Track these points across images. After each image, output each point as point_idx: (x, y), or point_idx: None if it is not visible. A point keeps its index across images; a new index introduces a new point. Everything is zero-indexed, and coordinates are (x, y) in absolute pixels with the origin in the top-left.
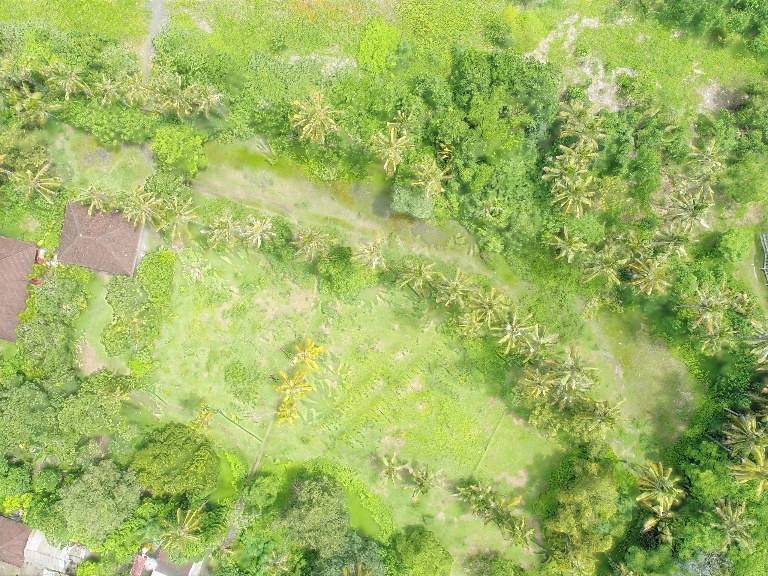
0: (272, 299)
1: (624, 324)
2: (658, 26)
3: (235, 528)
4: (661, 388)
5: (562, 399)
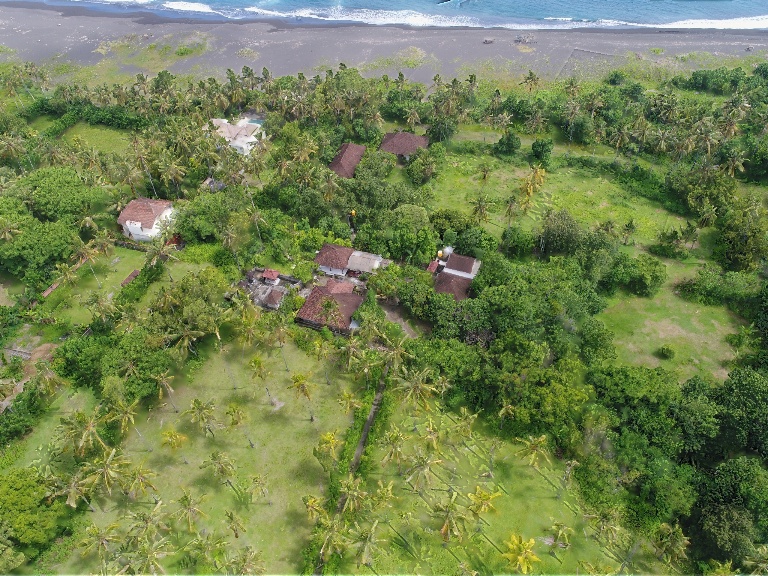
0: (503, 173)
1: None
2: (686, 90)
3: None
4: (767, 204)
5: None
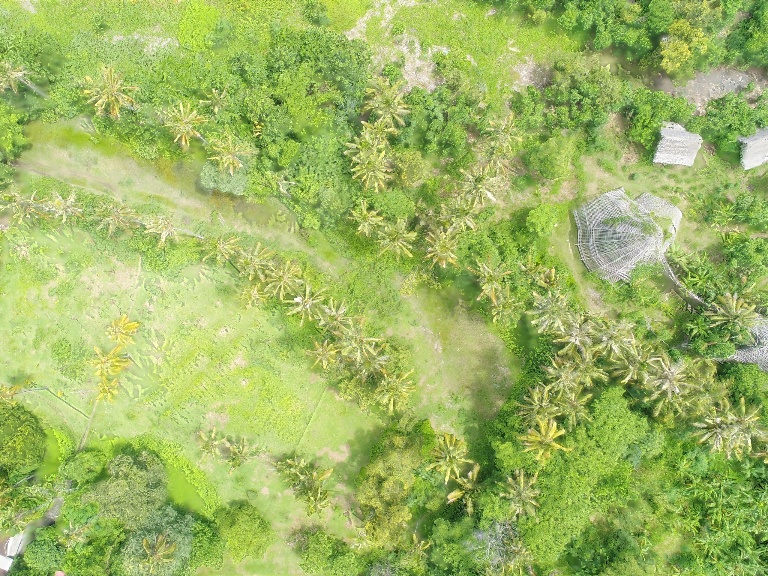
0: (97, 277)
1: (442, 300)
2: (472, 4)
3: (61, 503)
4: (479, 363)
5: (361, 372)
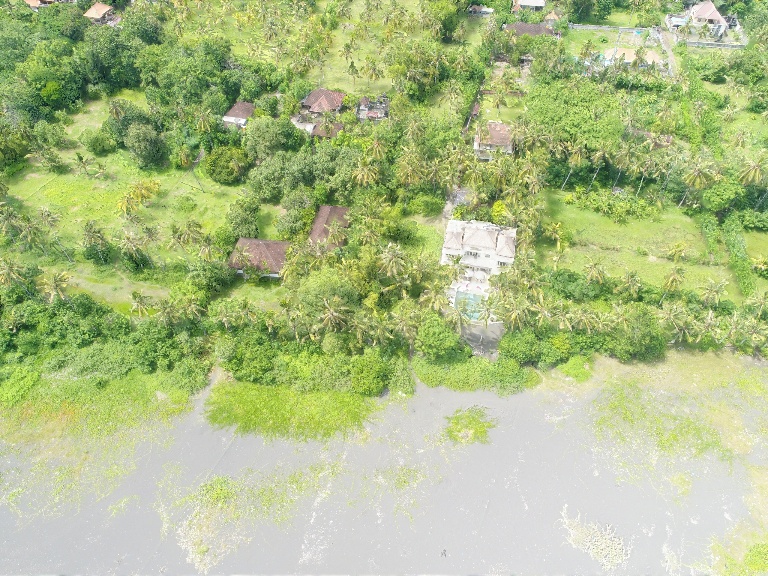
0: None
1: None
2: None
3: None
4: None
5: None
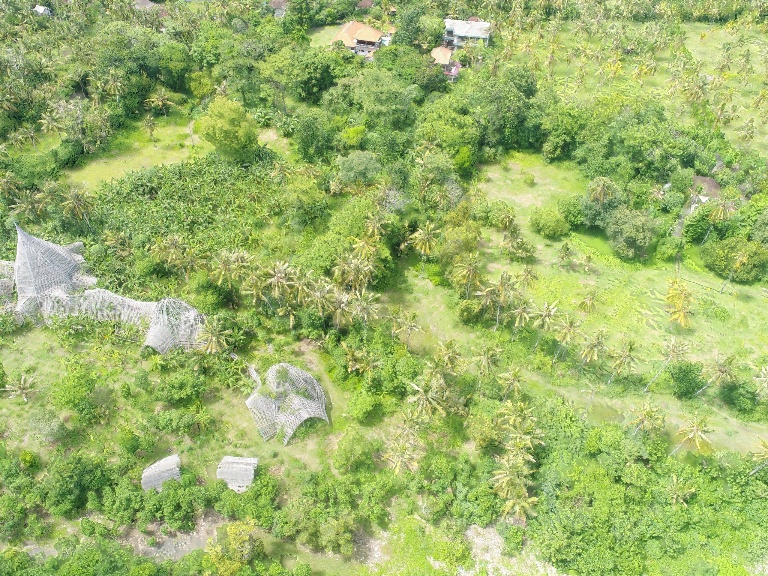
0: None
1: None
2: None
3: (675, 234)
4: None
5: None
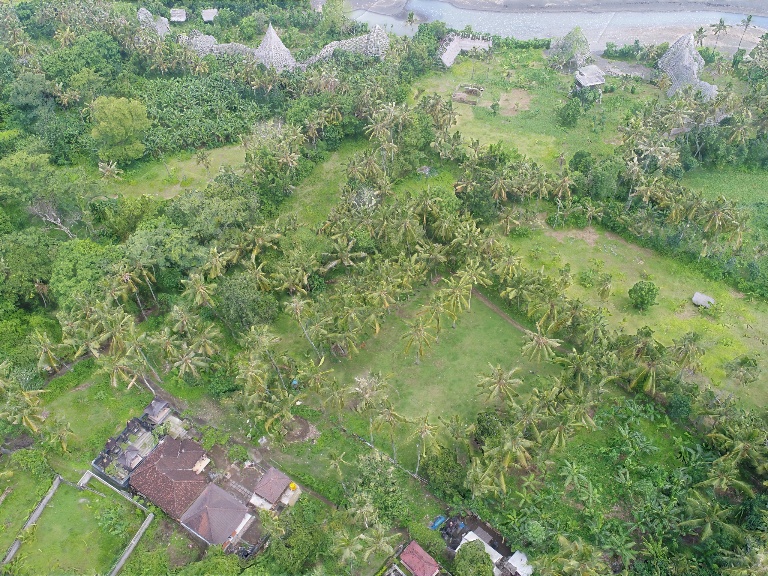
0: None
1: None
2: (124, 2)
3: None
4: None
5: None
